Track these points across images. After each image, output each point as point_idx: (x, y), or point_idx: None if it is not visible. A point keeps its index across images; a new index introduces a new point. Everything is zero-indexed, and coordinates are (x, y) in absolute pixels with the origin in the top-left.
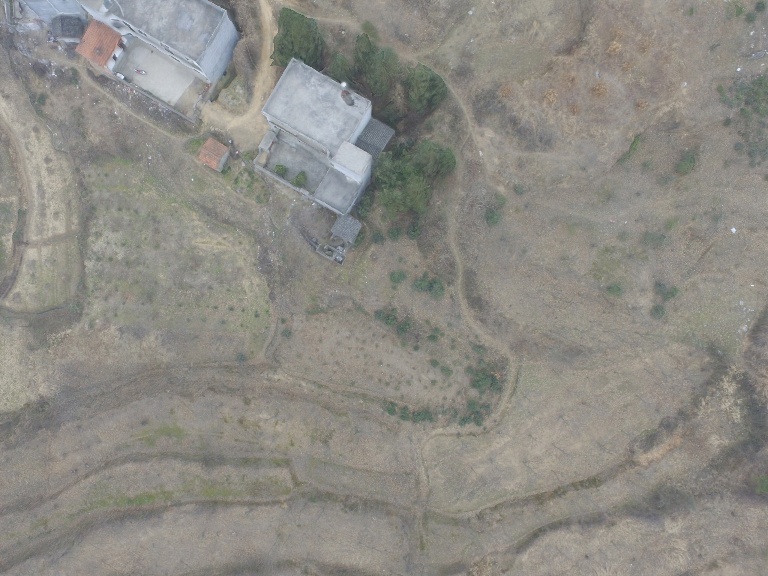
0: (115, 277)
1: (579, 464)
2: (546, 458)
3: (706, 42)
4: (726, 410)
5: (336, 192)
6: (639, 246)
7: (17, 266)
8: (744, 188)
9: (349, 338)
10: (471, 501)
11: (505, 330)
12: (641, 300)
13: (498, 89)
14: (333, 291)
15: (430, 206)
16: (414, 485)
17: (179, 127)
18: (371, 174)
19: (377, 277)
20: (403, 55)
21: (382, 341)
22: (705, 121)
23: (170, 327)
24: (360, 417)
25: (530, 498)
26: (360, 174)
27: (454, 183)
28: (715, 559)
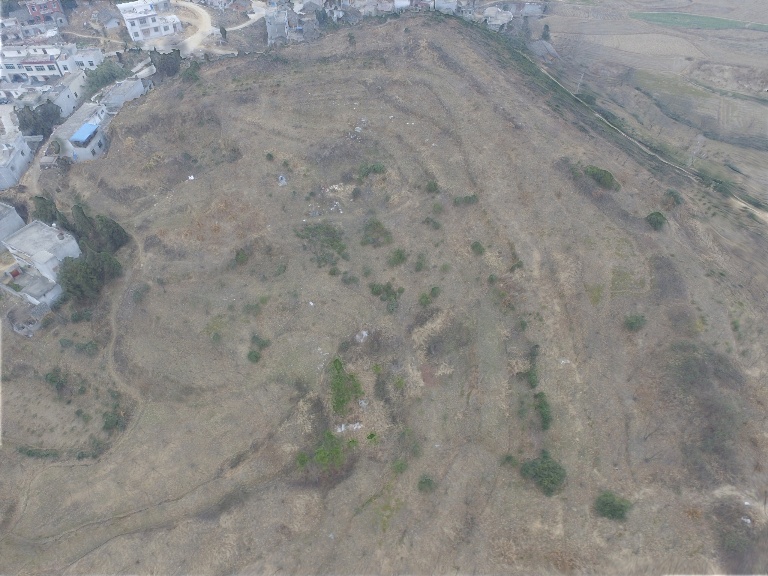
0: None
1: (172, 485)
2: (143, 481)
3: (281, 208)
4: (300, 423)
5: (38, 288)
6: (243, 314)
7: None
8: (316, 279)
9: (19, 398)
10: (56, 526)
11: (138, 377)
12: (240, 347)
13: (158, 233)
14: (19, 360)
15: (101, 295)
16: (6, 510)
17: None
18: None
19: (53, 346)
20: None
21: (45, 399)
22: (287, 245)
23: None
24: None
25: (113, 517)
26: (43, 264)
27: (122, 283)
28: (261, 551)
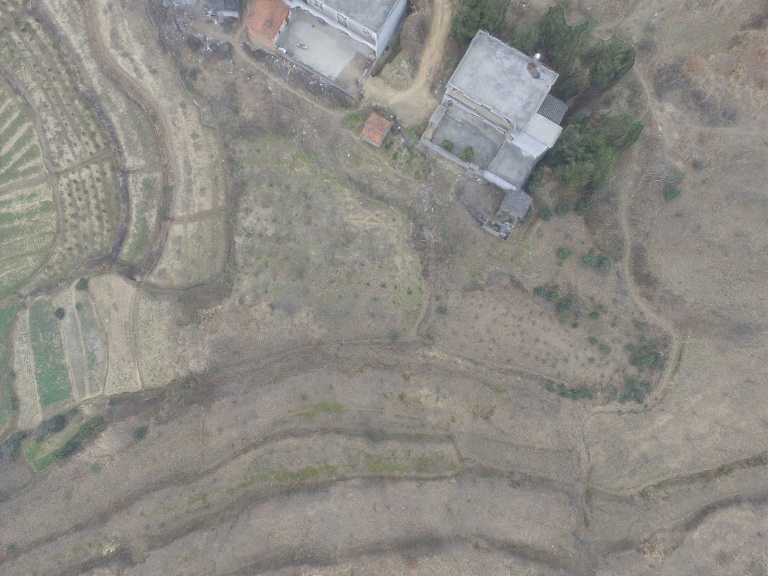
0: (265, 253)
1: (743, 442)
2: (710, 436)
3: None
4: None
5: (511, 166)
6: None
7: (163, 242)
8: None
9: (506, 315)
10: (633, 478)
11: (671, 307)
12: None
13: (683, 63)
14: (494, 268)
15: (604, 181)
16: (576, 462)
17: (339, 102)
18: (549, 148)
19: (542, 253)
20: None
21: (539, 318)
22: None
23: (321, 304)
24: (520, 394)
25: (695, 476)
26: (551, 146)
27: (630, 158)
28: None
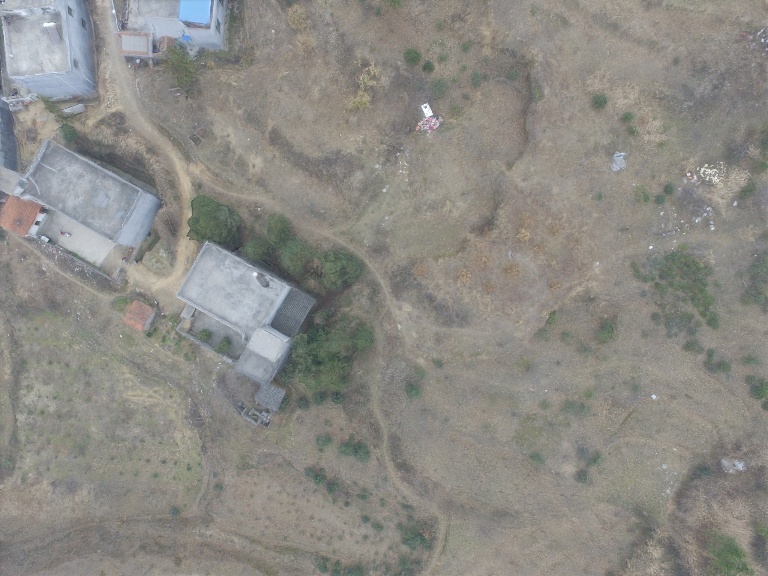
0: (47, 430)
1: None
2: None
3: (616, 224)
4: (651, 574)
5: (257, 364)
6: (560, 413)
7: None
8: (662, 357)
9: (280, 493)
10: None
11: (432, 491)
12: (564, 466)
13: (413, 267)
14: (261, 450)
15: (351, 376)
16: None
17: (105, 287)
18: None
19: (303, 439)
20: (319, 231)
21: (313, 496)
22: (620, 295)
23: (103, 480)
24: None
25: None
26: (274, 361)
27: (374, 353)
28: None
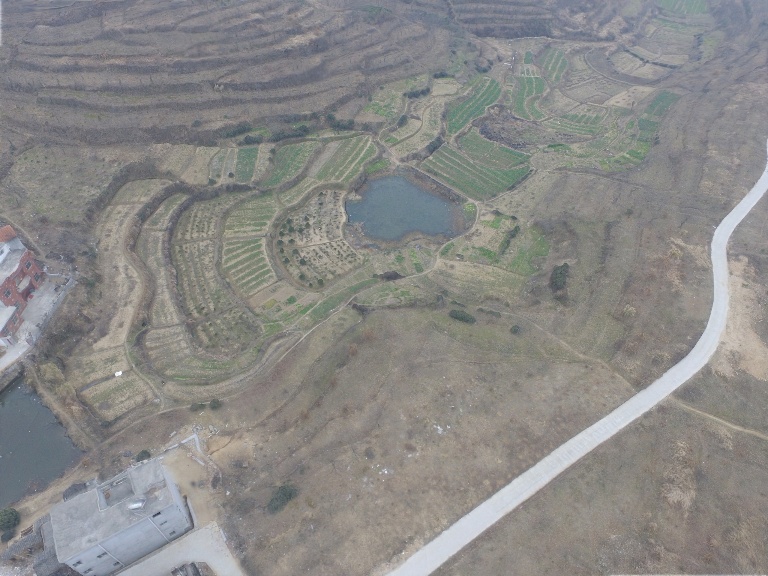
0: (95, 179)
1: None
2: None
3: None
4: None
5: None
6: None
7: None
8: None
9: None
10: None
11: None
12: None
13: None
14: None
15: None
16: None
17: None
18: None
19: None
20: None
21: None
22: None
23: None
24: None
25: None
26: None
27: None
28: None
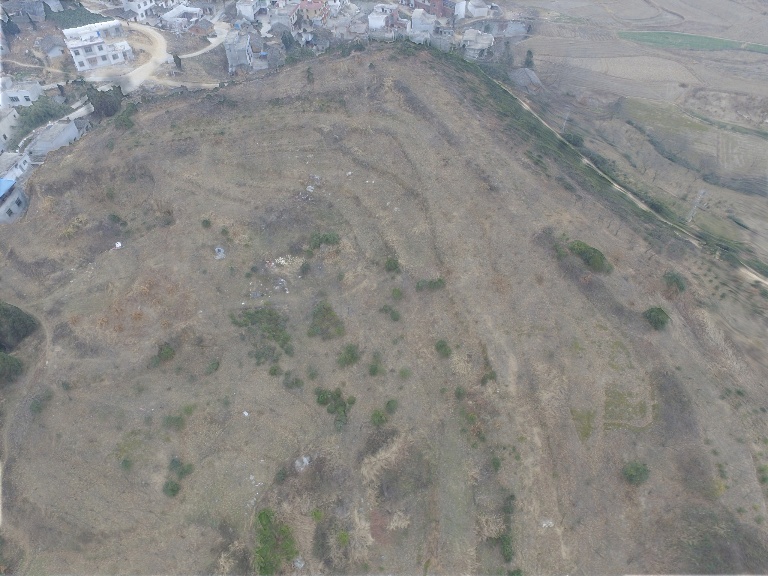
0: None
1: None
2: None
3: None
4: None
5: None
6: (162, 429)
7: None
8: (253, 381)
9: None
10: None
11: (28, 517)
12: (155, 476)
13: None
14: None
15: None
16: None
17: None
18: None
19: None
20: (17, 306)
21: None
22: (221, 335)
23: None
24: None
25: None
26: None
27: (21, 386)
28: None
